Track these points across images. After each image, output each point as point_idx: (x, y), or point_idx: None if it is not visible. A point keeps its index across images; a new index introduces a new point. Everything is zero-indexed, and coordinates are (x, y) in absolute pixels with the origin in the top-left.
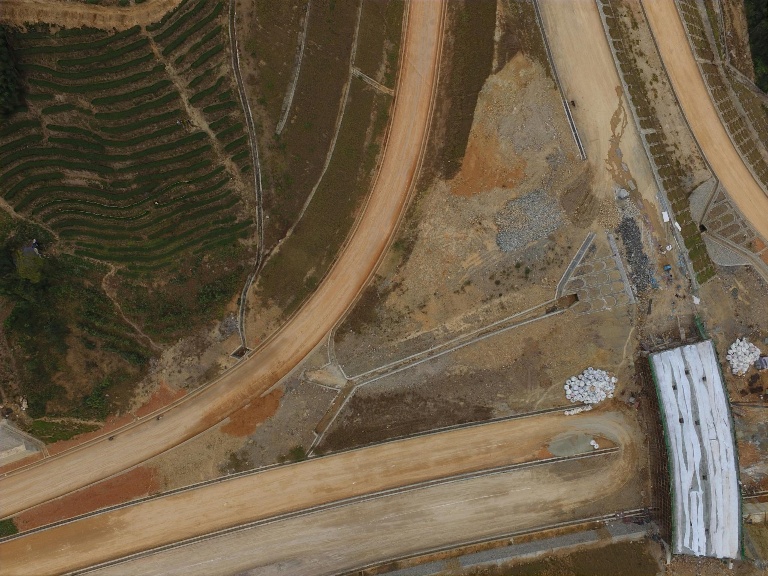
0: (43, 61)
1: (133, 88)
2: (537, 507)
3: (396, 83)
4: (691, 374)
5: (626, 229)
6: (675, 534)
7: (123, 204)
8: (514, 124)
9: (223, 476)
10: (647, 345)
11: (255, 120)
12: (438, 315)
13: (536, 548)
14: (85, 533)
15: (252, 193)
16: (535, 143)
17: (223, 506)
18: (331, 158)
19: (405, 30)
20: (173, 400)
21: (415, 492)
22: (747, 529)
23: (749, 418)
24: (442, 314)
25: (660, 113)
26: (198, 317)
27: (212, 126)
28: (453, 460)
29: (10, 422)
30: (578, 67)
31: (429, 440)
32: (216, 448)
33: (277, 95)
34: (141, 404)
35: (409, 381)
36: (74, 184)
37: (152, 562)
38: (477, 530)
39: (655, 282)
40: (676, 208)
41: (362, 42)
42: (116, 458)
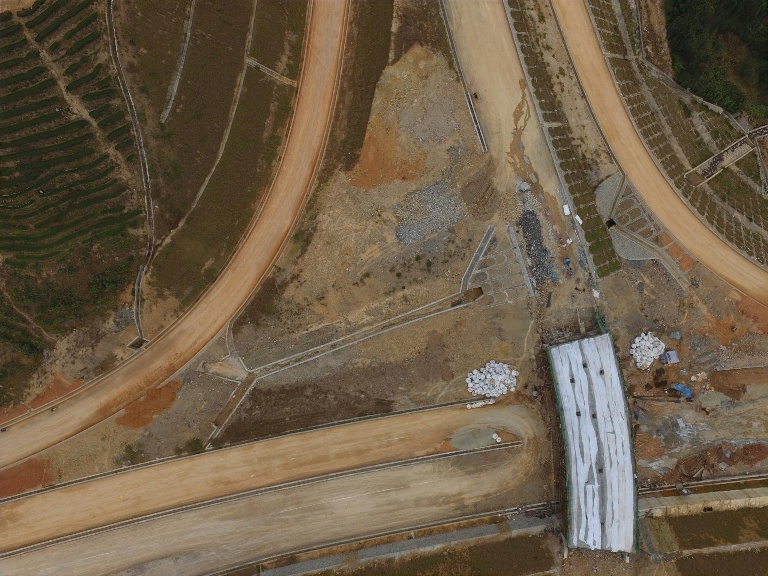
0: None
1: (8, 74)
2: (439, 501)
3: (299, 74)
4: (589, 367)
5: (526, 222)
6: (571, 527)
7: (7, 192)
8: (414, 116)
9: (119, 468)
10: (548, 338)
11: (137, 108)
12: (339, 307)
13: (435, 542)
14: None
15: (140, 182)
16: (436, 135)
17: (119, 498)
18: (224, 148)
19: (309, 21)
20: (68, 391)
21: (315, 485)
22: (647, 523)
23: (654, 412)
24: (343, 306)
25: (566, 107)
26: (91, 307)
27: (92, 114)
28: (354, 453)
29: None
30: (482, 60)
31: (329, 433)
32: (111, 440)
33: (161, 83)
34: (35, 395)
35: (311, 373)
36: None
37: (46, 555)
38: (378, 523)
39: (555, 275)
40: (578, 201)
41: (258, 32)
42: (9, 450)
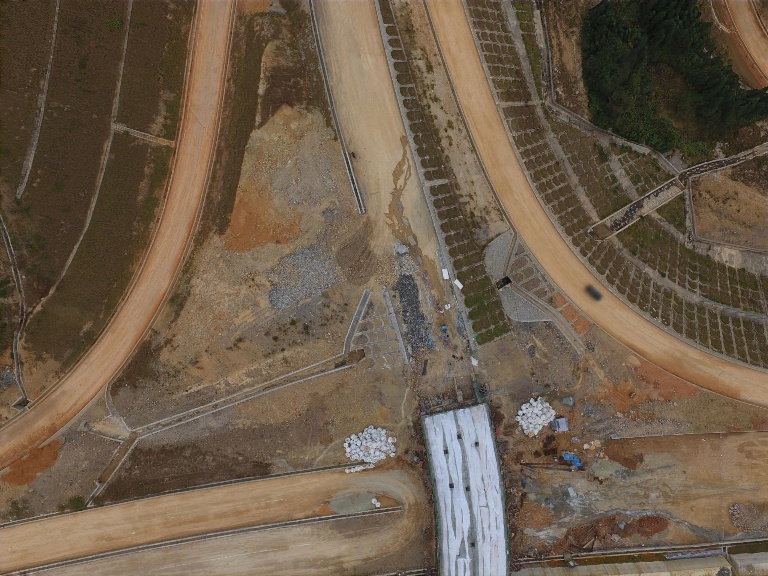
0: None
1: None
2: (317, 563)
3: (178, 134)
4: (463, 438)
5: (402, 287)
6: None
7: None
8: (288, 178)
9: (6, 522)
10: (427, 405)
11: None
12: (216, 370)
13: None
14: None
15: (5, 254)
16: (311, 197)
17: (7, 551)
18: (92, 216)
19: (187, 79)
20: None
21: (194, 544)
22: None
23: (542, 480)
24: (221, 369)
25: (454, 162)
26: None
27: None
28: (232, 514)
29: None
30: (362, 116)
31: (208, 493)
32: None
33: (15, 160)
34: None
35: (191, 434)
36: None
37: None
38: None
39: (431, 342)
40: (460, 264)
41: (126, 97)
42: None
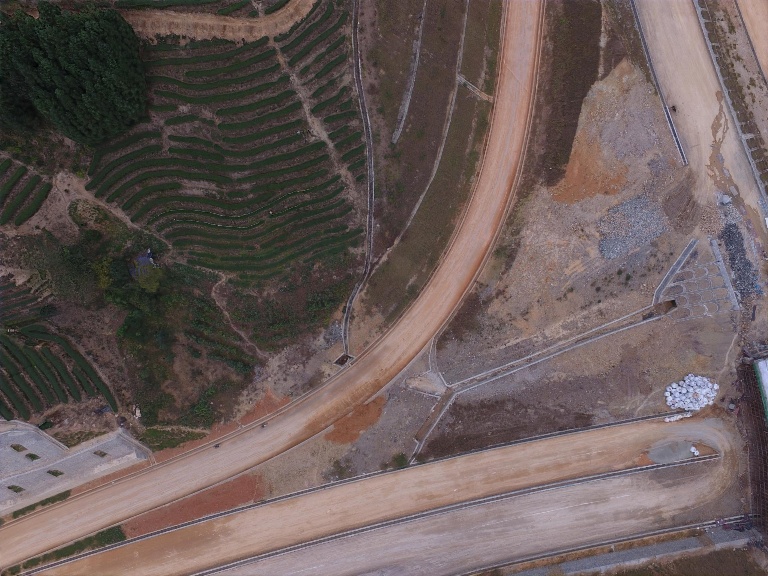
0: (170, 73)
1: (257, 99)
2: (637, 514)
3: (494, 90)
4: None
5: (730, 235)
6: None
7: (238, 214)
8: (616, 130)
9: (327, 483)
10: (749, 351)
11: (373, 129)
12: (538, 322)
13: (639, 555)
14: (191, 540)
15: (364, 202)
16: (637, 149)
17: (326, 513)
18: (438, 166)
19: (503, 36)
20: (277, 408)
21: (516, 499)
22: None
23: None
24: (542, 321)
25: (758, 118)
26: (305, 325)
27: (332, 136)
28: (553, 467)
29: (125, 431)
30: (678, 72)
31: (529, 447)
32: (320, 455)
33: (394, 104)
34: (245, 412)
35: (508, 388)
36: (191, 194)
37: (257, 569)
38: (577, 537)
39: (759, 288)
40: None
41: (467, 49)
42: (221, 465)
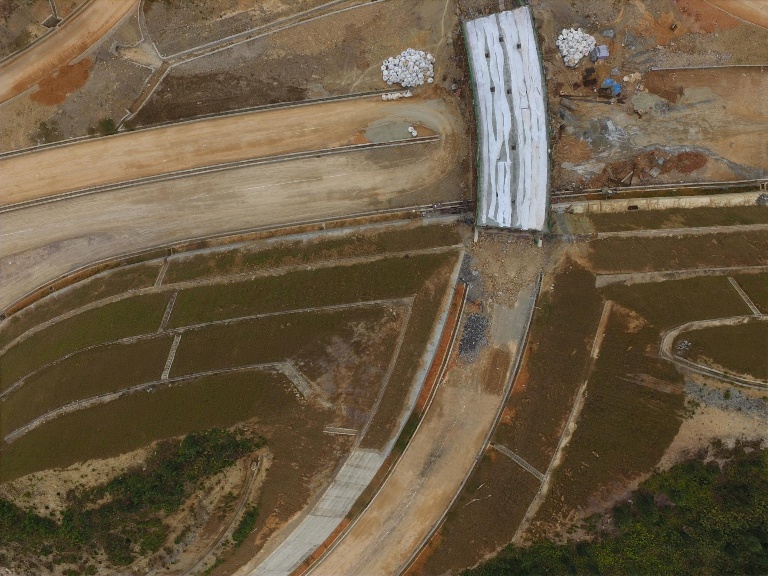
0: None
1: None
2: (352, 194)
3: None
4: (505, 41)
5: None
6: (480, 205)
7: None
8: None
9: (34, 146)
10: None
11: None
12: None
13: (344, 228)
14: None
15: None
16: None
17: (35, 177)
18: None
19: None
20: None
21: (226, 173)
22: (566, 216)
23: (581, 113)
24: None
25: None
26: None
27: None
28: (266, 142)
29: None
30: None
31: (242, 121)
32: (26, 116)
33: None
34: None
35: (225, 63)
36: None
37: None
38: (289, 215)
39: None
40: None
41: None
42: None
